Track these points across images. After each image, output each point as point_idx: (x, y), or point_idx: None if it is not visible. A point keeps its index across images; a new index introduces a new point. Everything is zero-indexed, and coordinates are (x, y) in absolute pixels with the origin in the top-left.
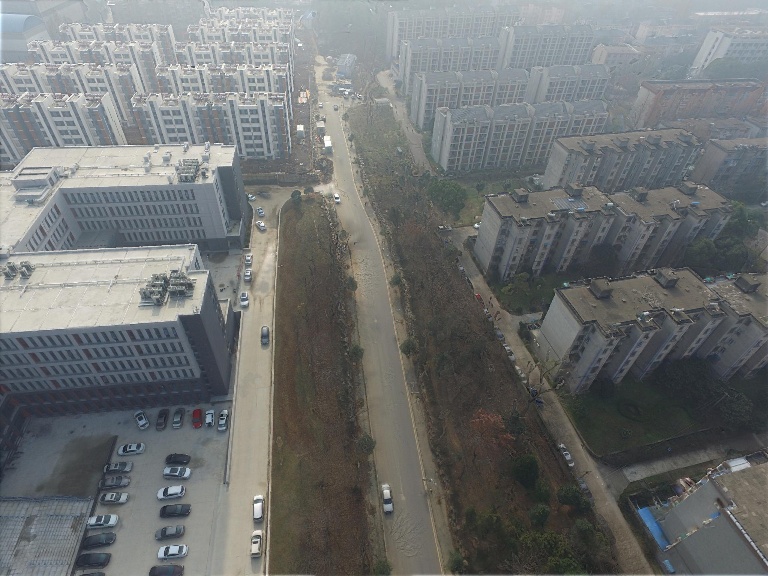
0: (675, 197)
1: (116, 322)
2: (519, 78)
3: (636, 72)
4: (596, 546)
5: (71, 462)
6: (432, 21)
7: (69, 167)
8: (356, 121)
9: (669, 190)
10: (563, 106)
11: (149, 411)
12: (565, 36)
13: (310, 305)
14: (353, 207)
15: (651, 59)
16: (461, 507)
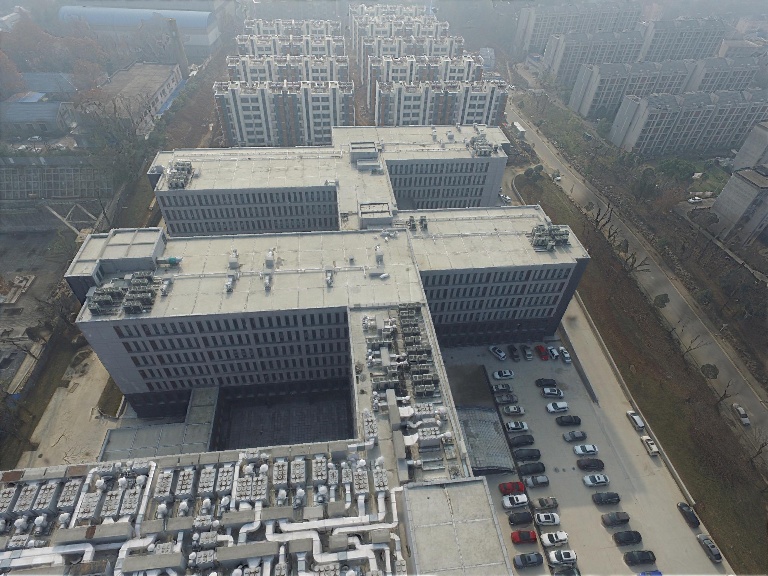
0: None
1: (529, 263)
2: (680, 69)
3: None
4: None
5: (459, 384)
6: (565, 17)
7: (381, 143)
8: (526, 109)
9: None
10: (741, 94)
11: (497, 347)
12: (700, 30)
13: (596, 263)
14: (574, 184)
15: None
16: None
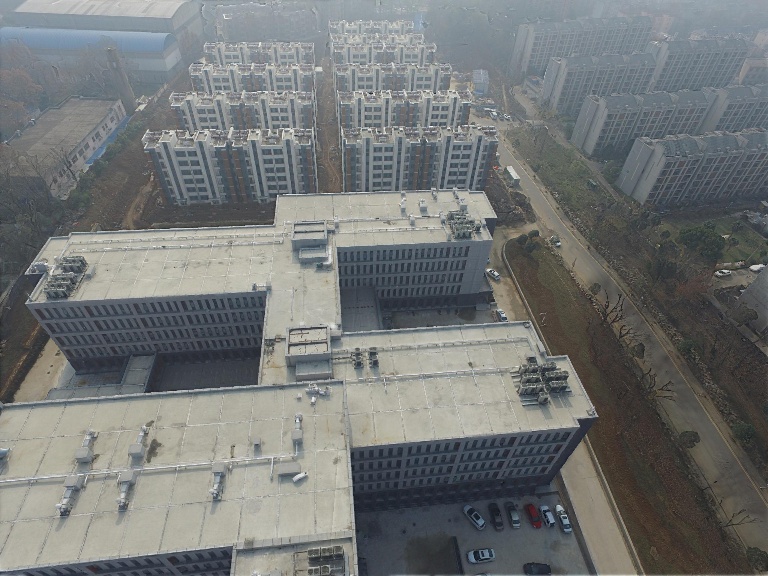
0: None
1: (513, 428)
2: (699, 101)
3: None
4: None
5: (421, 571)
6: (567, 34)
7: (334, 221)
8: (522, 147)
9: None
10: None
11: (475, 505)
12: (719, 51)
13: (604, 376)
14: (577, 251)
15: None
16: None
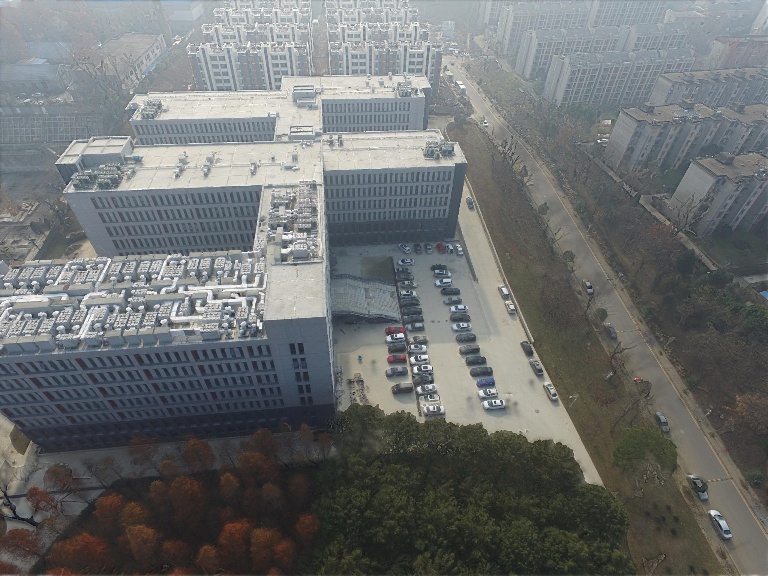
0: (766, 110)
1: (417, 166)
2: (612, 34)
3: (706, 31)
4: (742, 294)
5: (369, 269)
6: None
7: (320, 87)
8: (474, 72)
9: (760, 106)
10: (658, 53)
11: None
12: (643, 1)
13: (498, 184)
14: (499, 129)
15: (720, 19)
16: (640, 290)
